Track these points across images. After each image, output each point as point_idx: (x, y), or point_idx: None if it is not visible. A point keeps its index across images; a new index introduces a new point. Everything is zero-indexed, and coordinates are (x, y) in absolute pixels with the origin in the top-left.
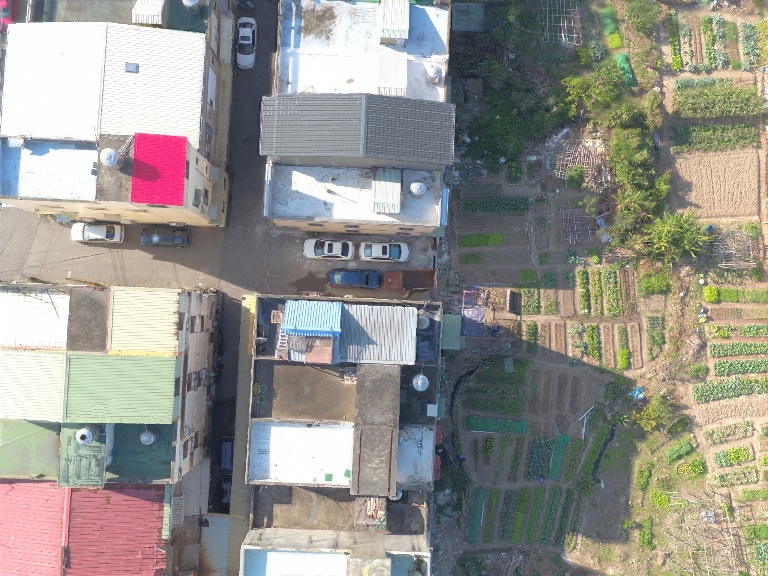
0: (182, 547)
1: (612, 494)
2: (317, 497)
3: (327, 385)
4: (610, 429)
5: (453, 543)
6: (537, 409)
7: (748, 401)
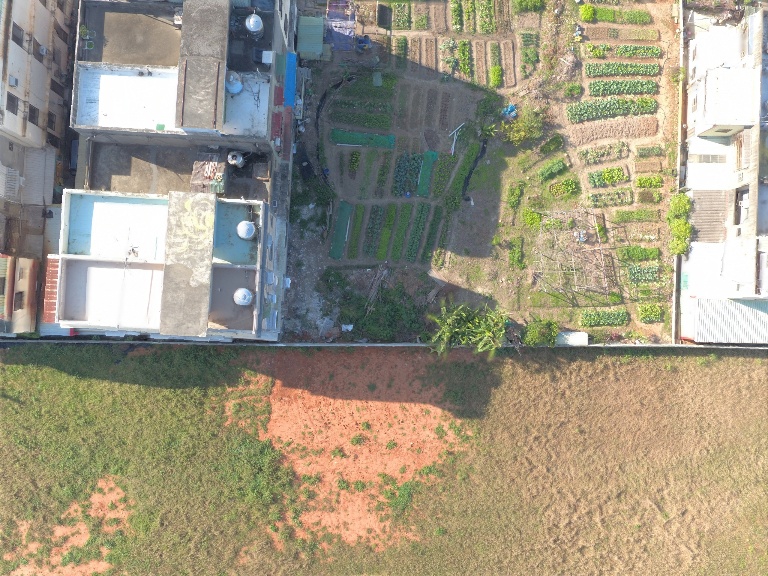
0: (23, 235)
1: (482, 212)
2: (158, 169)
3: (160, 34)
4: (481, 147)
5: (317, 259)
6: (405, 124)
7: (623, 122)
